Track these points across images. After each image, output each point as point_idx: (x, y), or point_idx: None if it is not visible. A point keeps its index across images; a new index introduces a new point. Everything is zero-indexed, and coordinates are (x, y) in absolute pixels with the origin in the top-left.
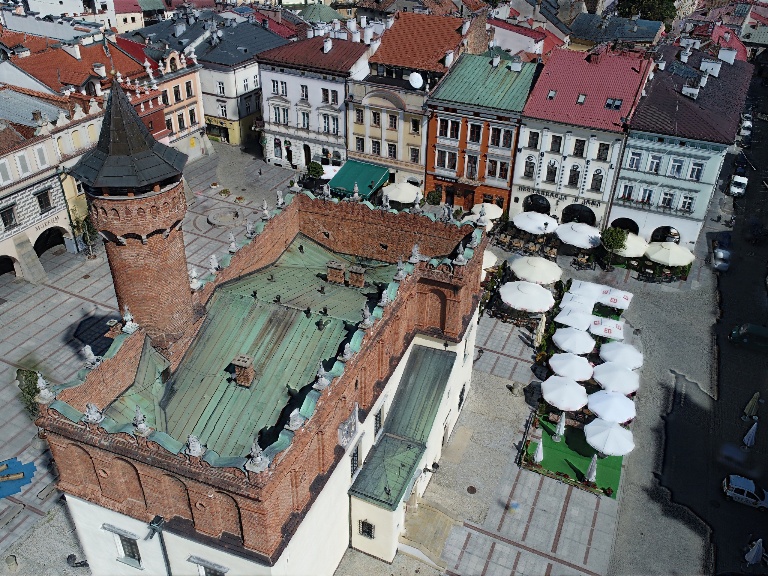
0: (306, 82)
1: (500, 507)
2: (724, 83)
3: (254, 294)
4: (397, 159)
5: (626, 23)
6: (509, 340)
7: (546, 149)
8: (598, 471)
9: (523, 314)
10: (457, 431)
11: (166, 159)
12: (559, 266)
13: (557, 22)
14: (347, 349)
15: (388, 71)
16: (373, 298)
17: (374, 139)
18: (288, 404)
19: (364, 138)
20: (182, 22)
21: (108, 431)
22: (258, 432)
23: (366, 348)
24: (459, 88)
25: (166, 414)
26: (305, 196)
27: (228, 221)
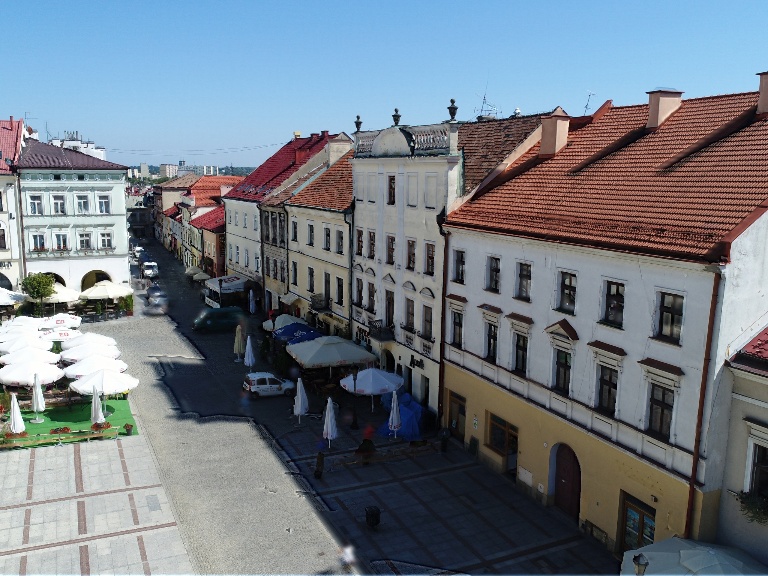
0: None
1: None
2: None
3: None
4: None
5: None
6: None
7: None
8: None
9: None
10: None
11: None
12: None
13: None
14: None
15: None
16: None
17: None
18: None
19: None
20: None
21: None
22: None
23: None
24: None
25: None
26: None
27: None
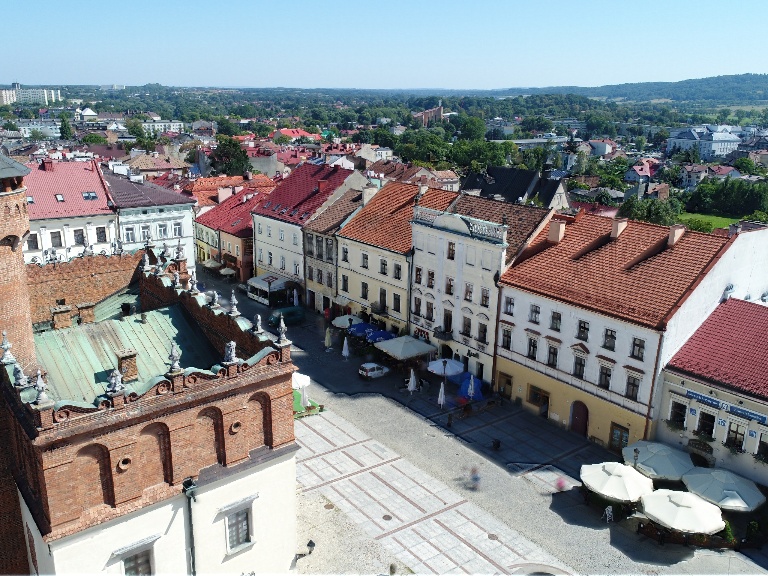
0: None
1: None
2: None
3: (52, 326)
4: None
5: None
6: None
7: (48, 247)
8: None
9: None
10: None
11: None
12: None
13: None
14: None
15: None
16: None
17: None
18: None
19: None
20: None
21: (138, 395)
22: None
23: None
24: None
25: None
26: None
27: None
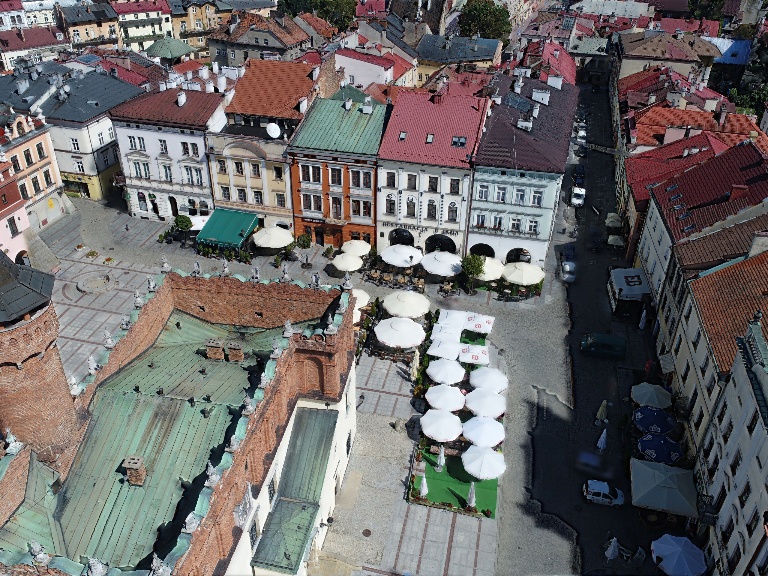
0: (164, 137)
1: (394, 545)
2: (554, 110)
3: (136, 389)
4: (264, 205)
5: (467, 42)
6: (388, 377)
7: (403, 187)
8: (478, 494)
9: (399, 349)
10: (348, 477)
11: (33, 287)
12: (427, 295)
13: (404, 46)
14: (233, 441)
15: (245, 120)
16: (254, 372)
17: (239, 187)
18: (183, 497)
19: (229, 187)
20: (24, 78)
21: (6, 564)
22: (156, 529)
23: (251, 432)
24: (316, 134)
25: (61, 525)
26: (176, 275)
27: (99, 286)
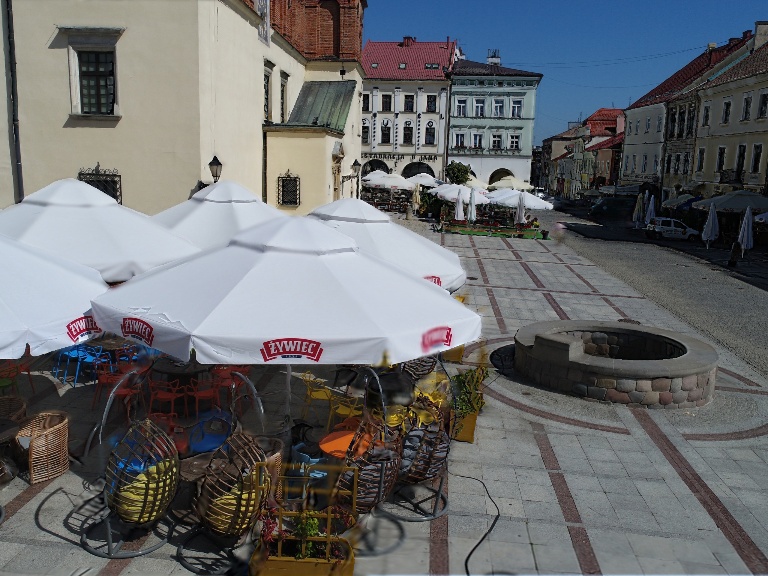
0: None
1: None
2: None
3: None
4: None
5: None
6: None
7: (378, 109)
8: None
9: None
10: None
11: None
12: None
13: None
14: None
15: None
16: None
17: None
18: None
19: None
20: None
21: None
22: None
23: None
24: None
25: None
26: None
27: None
